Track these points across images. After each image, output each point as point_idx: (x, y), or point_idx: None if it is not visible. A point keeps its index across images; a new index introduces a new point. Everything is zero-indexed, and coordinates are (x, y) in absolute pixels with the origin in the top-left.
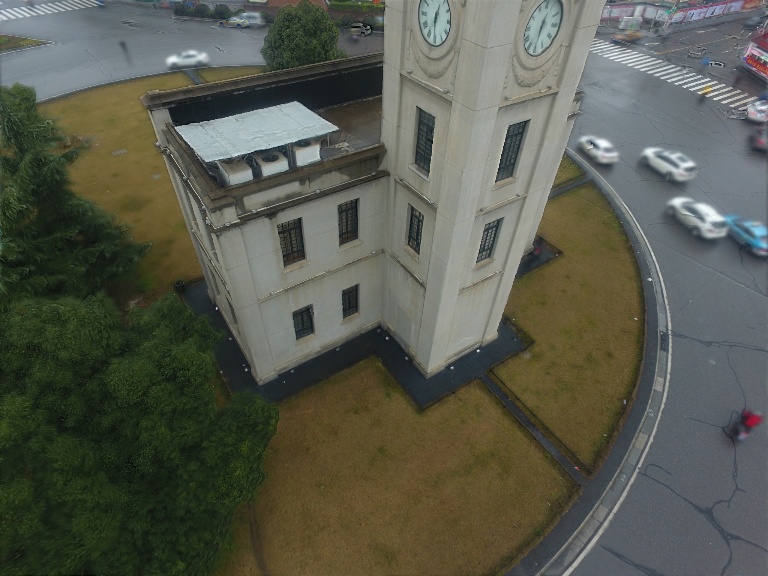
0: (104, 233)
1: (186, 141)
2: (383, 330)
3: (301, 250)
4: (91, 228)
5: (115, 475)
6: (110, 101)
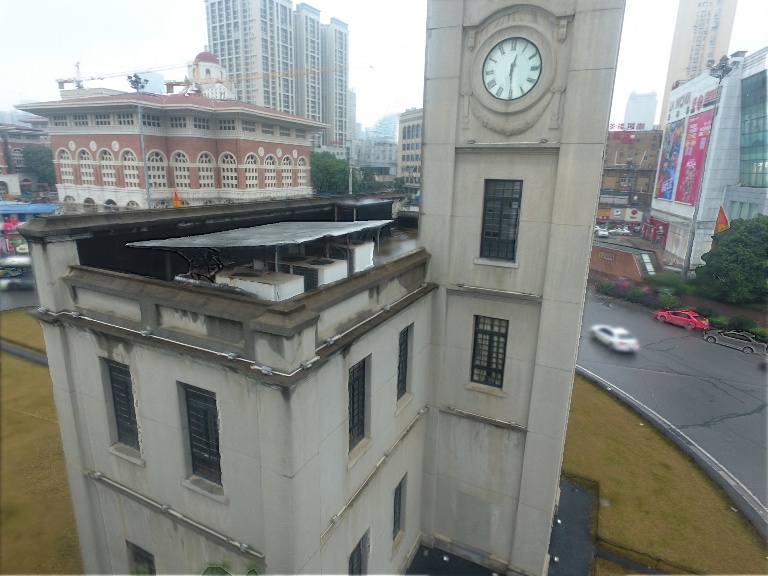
0: None
1: (177, 246)
2: (431, 549)
3: (360, 420)
4: None
5: None
6: None
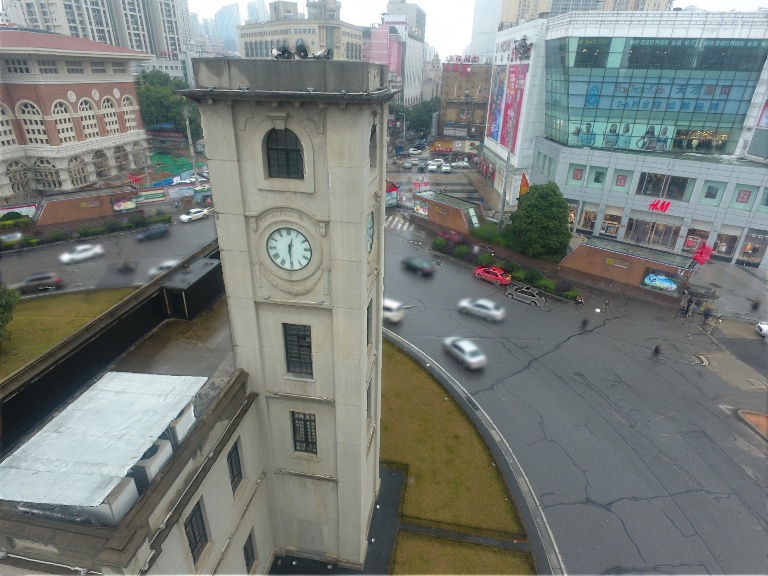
0: None
1: (16, 500)
2: (283, 558)
3: (203, 534)
4: None
5: None
6: None
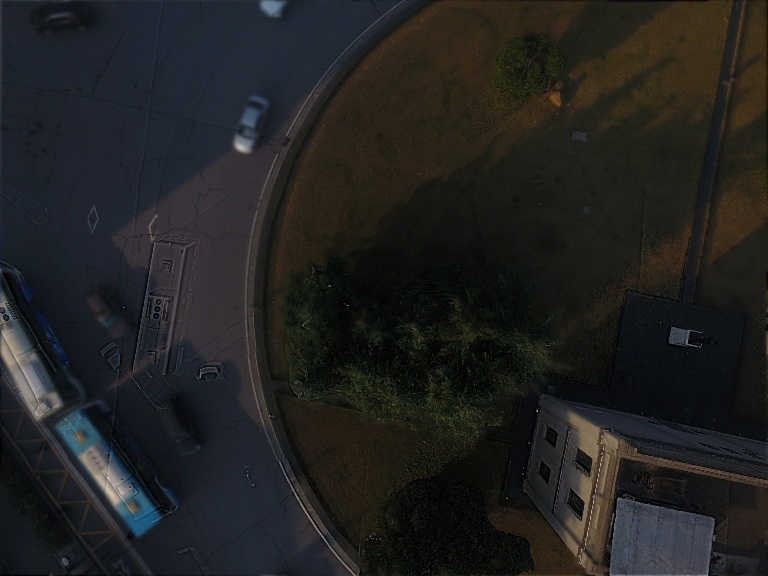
0: None
1: (614, 529)
2: None
3: None
4: None
5: None
6: (622, 4)
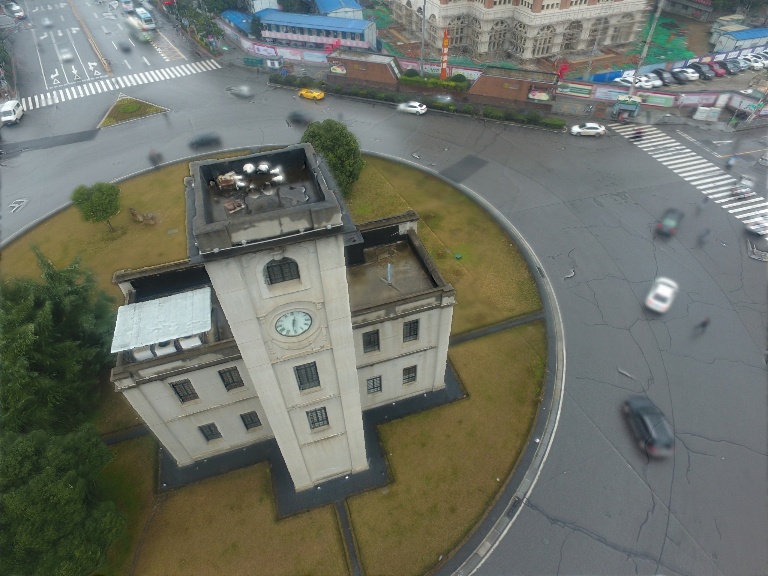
0: (107, 334)
1: None
2: None
3: (196, 393)
4: (98, 331)
5: (5, 550)
6: None
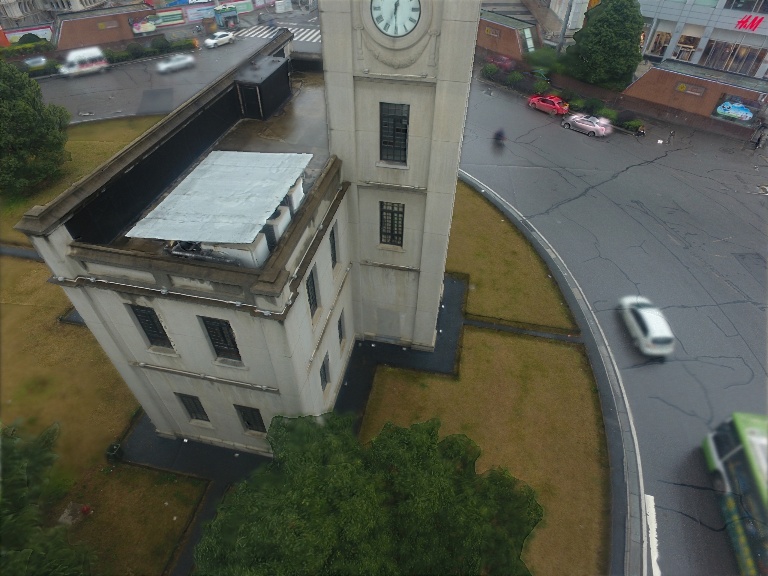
0: None
1: (174, 240)
2: (363, 342)
3: (314, 299)
4: None
5: None
6: None
